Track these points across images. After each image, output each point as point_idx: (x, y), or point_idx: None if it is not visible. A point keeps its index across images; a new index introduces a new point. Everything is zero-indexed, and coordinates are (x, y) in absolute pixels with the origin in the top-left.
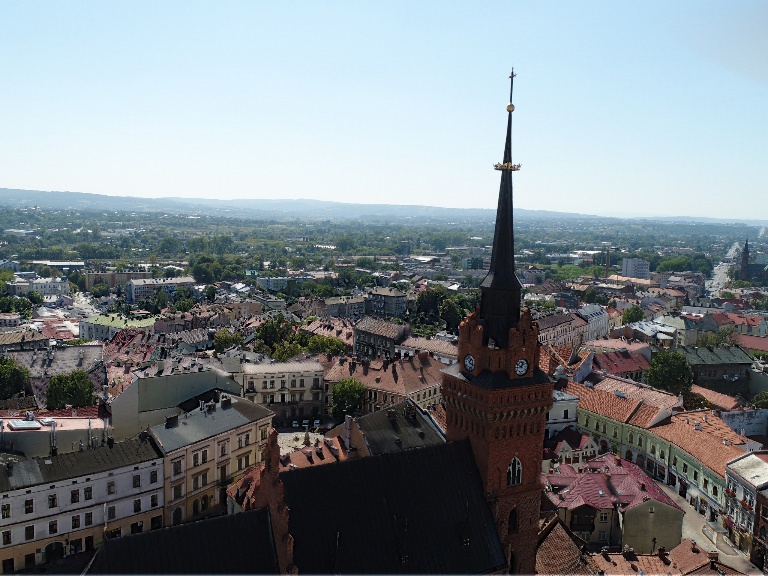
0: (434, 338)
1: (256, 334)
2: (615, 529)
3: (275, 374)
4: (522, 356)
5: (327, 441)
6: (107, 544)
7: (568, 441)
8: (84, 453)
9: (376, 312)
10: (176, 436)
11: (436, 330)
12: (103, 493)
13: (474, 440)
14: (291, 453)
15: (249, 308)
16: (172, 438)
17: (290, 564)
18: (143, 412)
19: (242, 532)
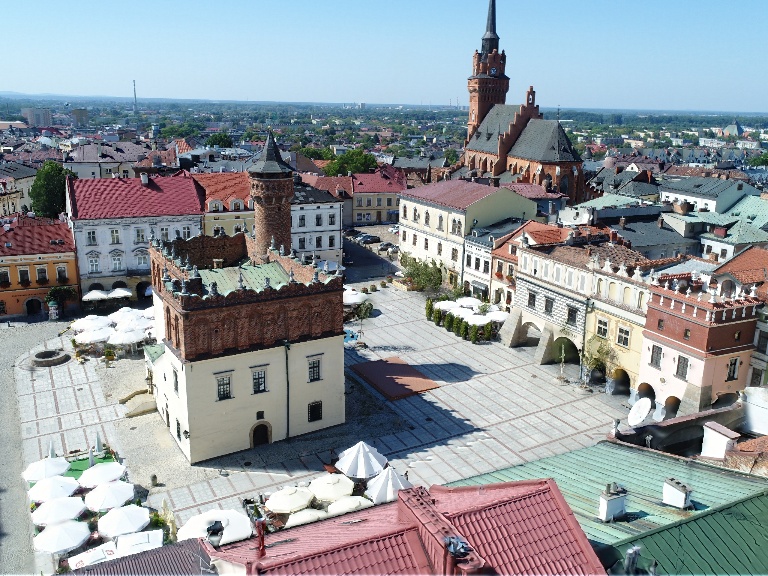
0: None
1: None
2: None
3: None
4: None
5: None
6: None
7: None
8: None
9: None
10: None
11: None
12: None
13: None
14: (304, 174)
15: None
16: None
17: None
18: None
19: None
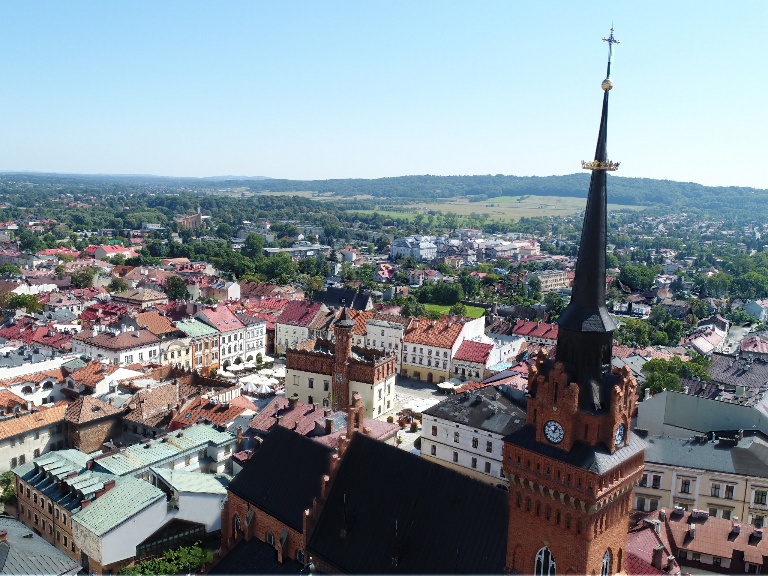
0: None
1: None
2: None
3: None
4: (554, 417)
5: None
6: (275, 426)
7: None
8: None
9: None
10: None
11: None
12: None
13: None
14: None
15: None
16: None
17: (323, 498)
18: (669, 425)
19: None
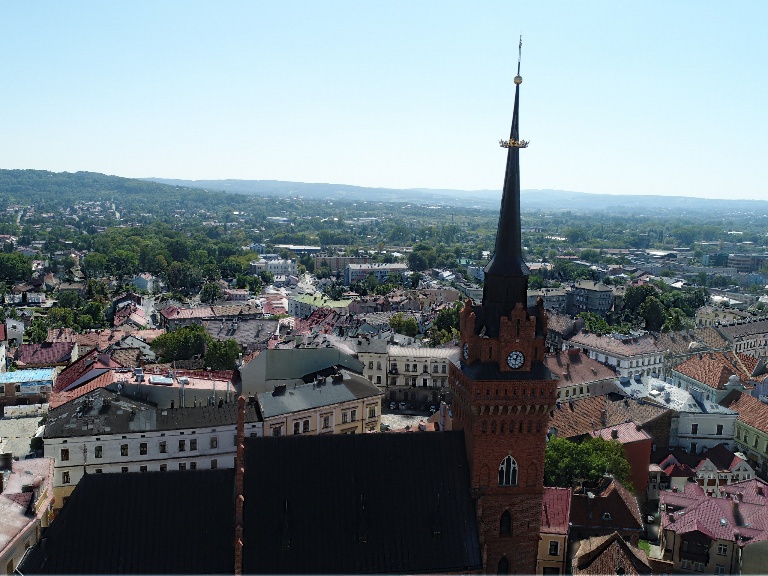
0: (609, 336)
1: (434, 320)
2: (735, 565)
3: (418, 358)
4: (516, 348)
5: (421, 425)
6: (86, 478)
7: (717, 460)
8: (196, 409)
9: (578, 306)
10: (279, 404)
11: (633, 329)
12: (207, 446)
13: (466, 432)
14: None
15: (446, 295)
16: (275, 405)
17: None
18: (270, 380)
19: (208, 487)
